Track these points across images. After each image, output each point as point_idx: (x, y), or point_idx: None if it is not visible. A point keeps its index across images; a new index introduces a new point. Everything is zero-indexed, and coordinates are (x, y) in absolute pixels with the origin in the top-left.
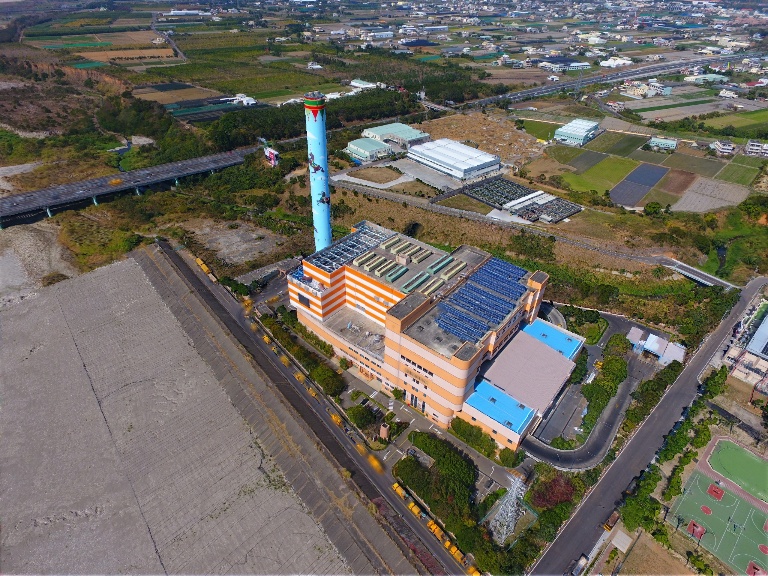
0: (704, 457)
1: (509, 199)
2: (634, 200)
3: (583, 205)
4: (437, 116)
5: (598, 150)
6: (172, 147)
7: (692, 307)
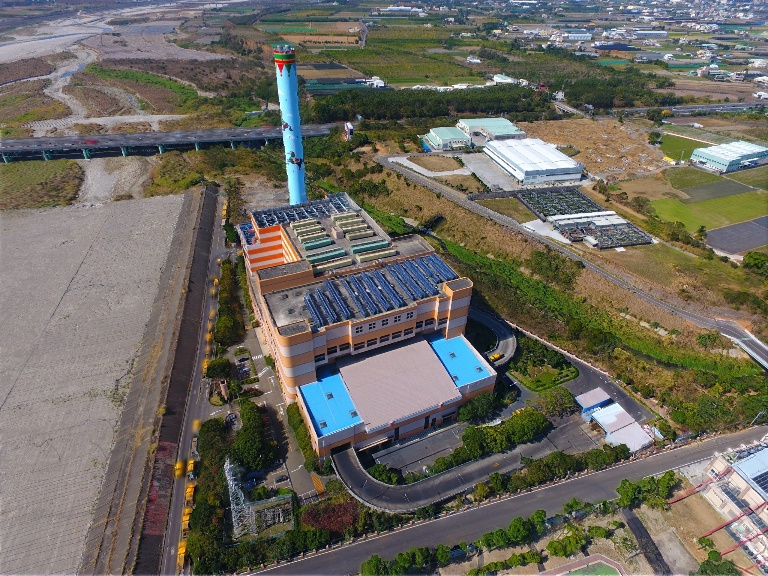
0: (557, 570)
1: (563, 212)
2: (742, 246)
3: (658, 237)
4: (558, 118)
5: (745, 181)
6: None
7: (717, 393)
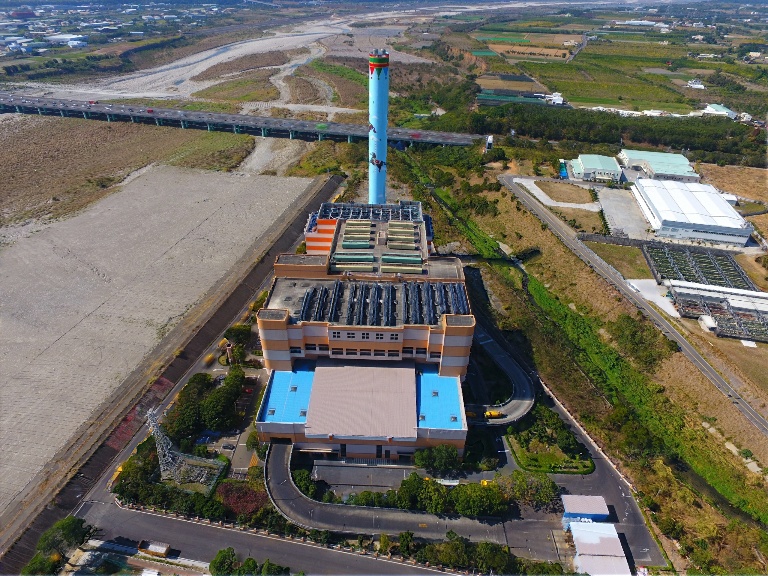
0: None
1: (691, 279)
2: None
3: None
4: (766, 165)
5: None
6: (443, 120)
7: None
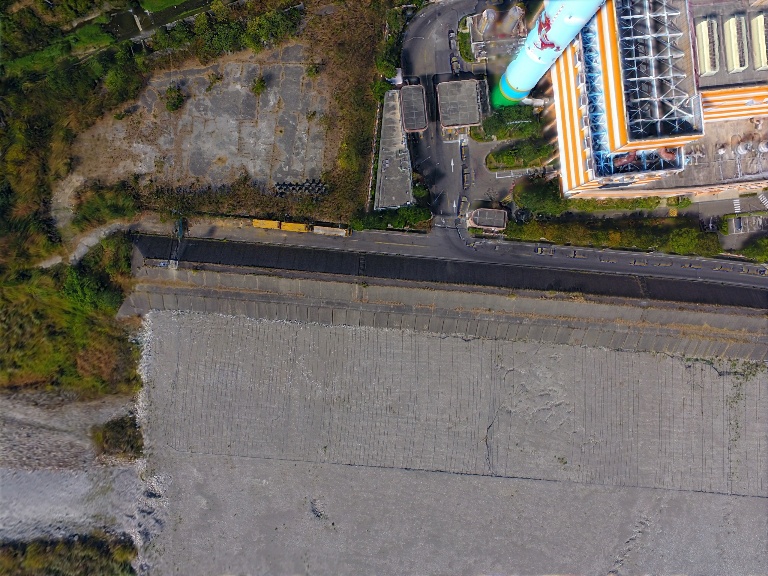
0: None
1: None
2: None
3: None
4: None
5: None
6: None
7: None
